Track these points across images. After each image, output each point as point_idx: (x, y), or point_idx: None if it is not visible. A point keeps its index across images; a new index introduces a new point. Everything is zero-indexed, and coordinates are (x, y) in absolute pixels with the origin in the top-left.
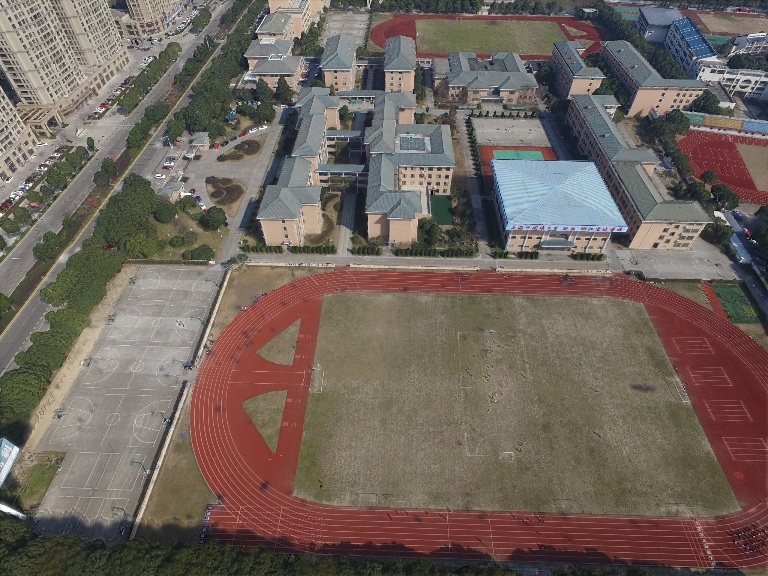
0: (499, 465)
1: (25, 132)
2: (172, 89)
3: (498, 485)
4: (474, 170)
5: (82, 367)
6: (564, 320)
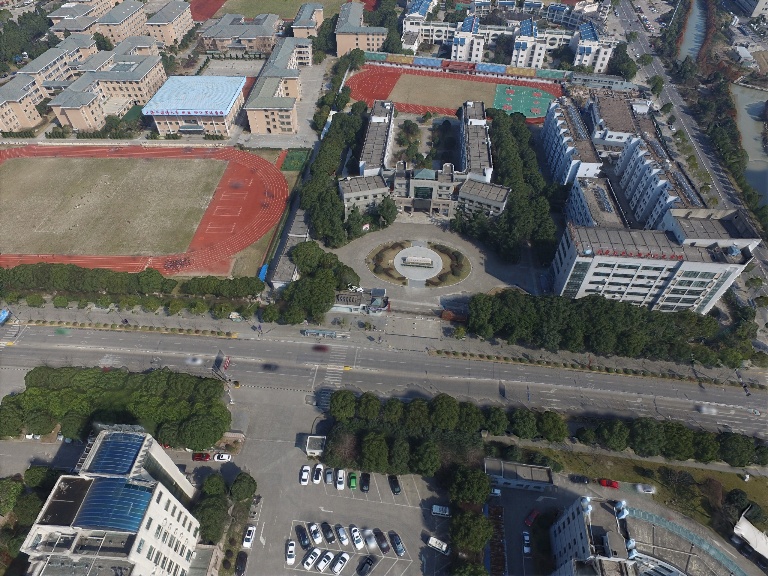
0: (51, 235)
1: None
2: None
3: (41, 244)
4: None
5: None
6: (164, 170)
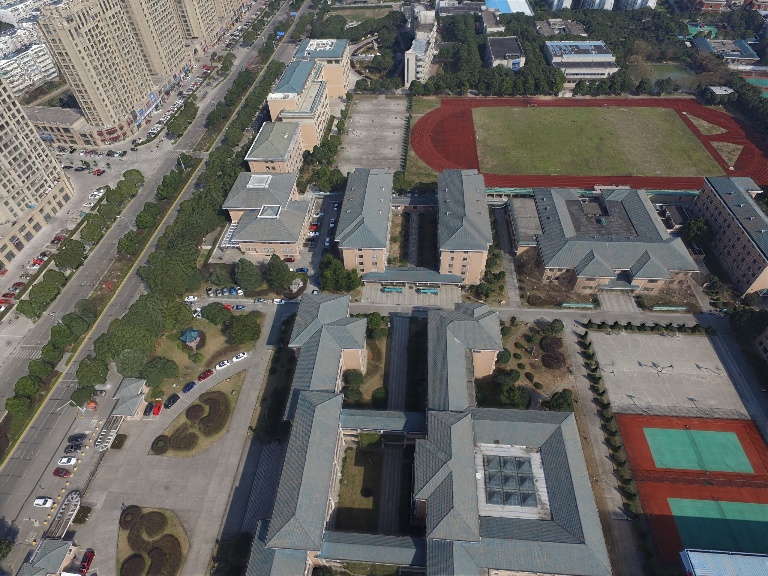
0: None
1: None
2: (117, 257)
3: None
4: (620, 495)
5: None
6: None
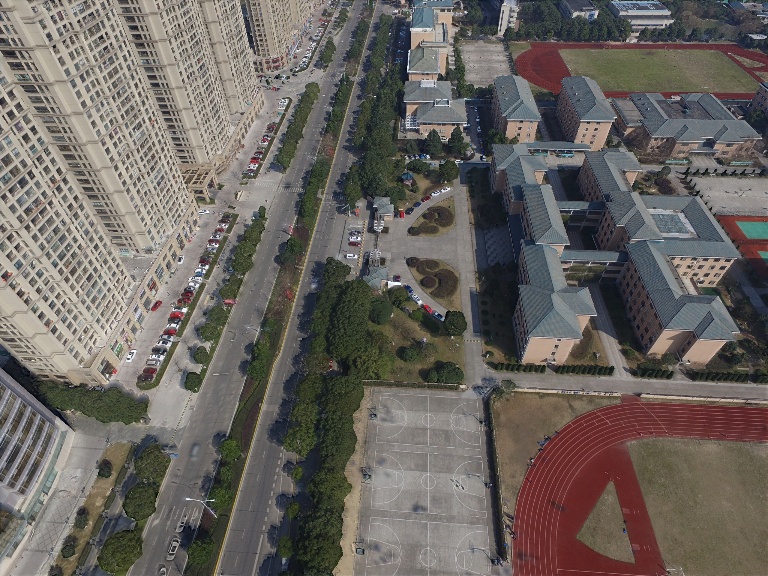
0: None
1: (189, 200)
2: (322, 138)
3: None
4: None
5: (356, 555)
6: None
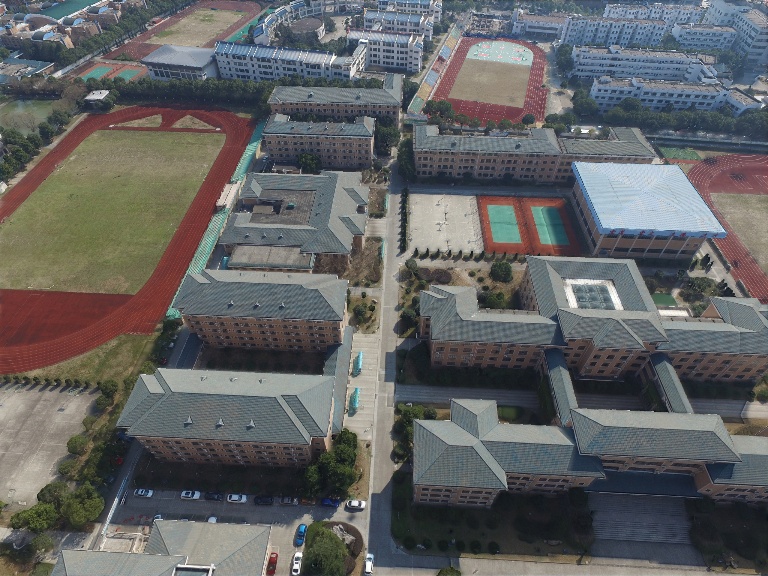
0: None
1: None
2: None
3: None
4: None
5: None
6: (765, 237)
